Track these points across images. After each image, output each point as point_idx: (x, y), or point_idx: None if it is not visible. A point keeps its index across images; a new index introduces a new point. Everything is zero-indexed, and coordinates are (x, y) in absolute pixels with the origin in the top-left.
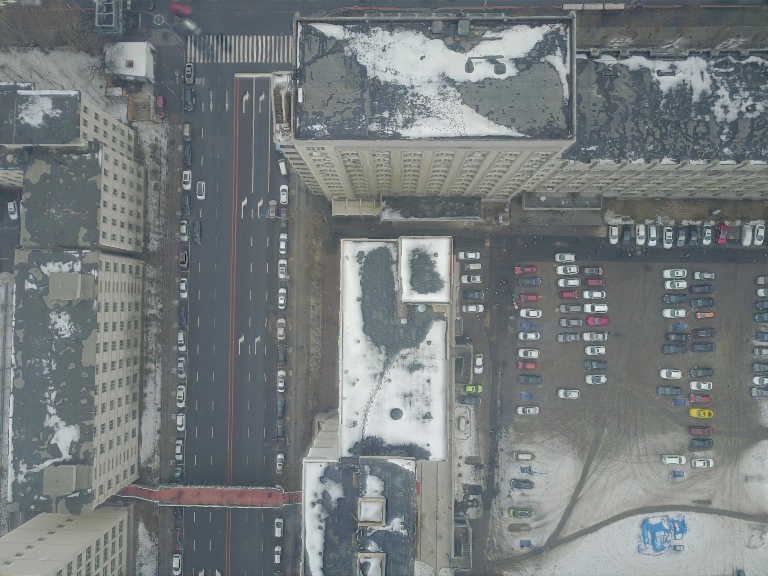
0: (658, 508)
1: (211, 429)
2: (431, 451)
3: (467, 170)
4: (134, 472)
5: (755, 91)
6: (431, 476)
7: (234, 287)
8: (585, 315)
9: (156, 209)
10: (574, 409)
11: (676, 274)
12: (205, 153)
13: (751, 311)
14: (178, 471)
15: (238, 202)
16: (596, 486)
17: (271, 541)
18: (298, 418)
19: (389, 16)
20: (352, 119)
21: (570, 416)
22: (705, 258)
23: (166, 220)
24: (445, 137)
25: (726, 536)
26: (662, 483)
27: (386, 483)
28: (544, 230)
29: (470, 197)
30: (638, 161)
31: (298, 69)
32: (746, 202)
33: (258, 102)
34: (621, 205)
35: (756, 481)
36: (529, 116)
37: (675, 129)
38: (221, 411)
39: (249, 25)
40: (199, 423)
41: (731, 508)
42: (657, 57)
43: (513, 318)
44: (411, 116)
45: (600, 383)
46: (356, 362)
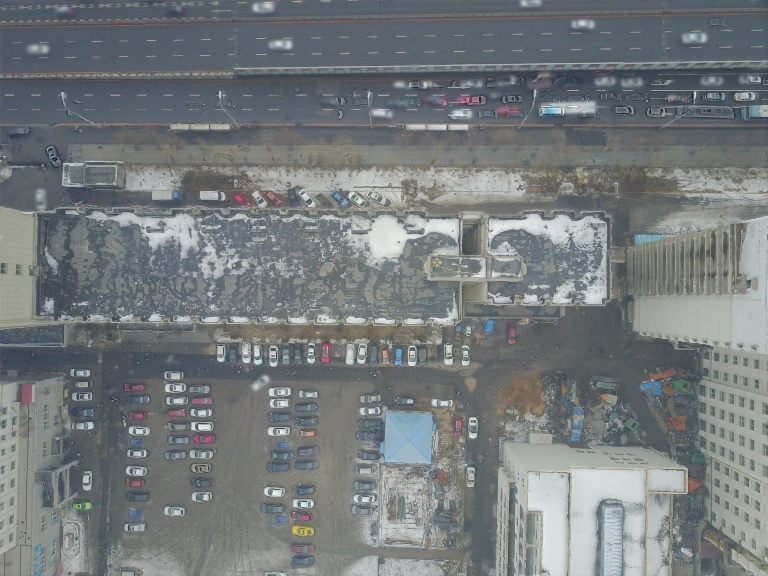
0: None
1: None
2: None
3: None
4: None
5: (241, 248)
6: None
7: None
8: (193, 432)
9: None
10: (181, 526)
11: (279, 393)
12: None
13: (355, 429)
14: None
15: None
16: None
17: None
18: None
19: None
20: None
21: (177, 532)
22: (311, 376)
23: None
24: None
25: None
26: None
27: None
28: (155, 347)
29: None
30: (127, 317)
31: None
32: None
33: None
34: None
35: None
36: None
37: (164, 285)
38: None
39: None
40: None
41: None
42: (142, 215)
43: (120, 436)
44: None
45: (205, 501)
46: None
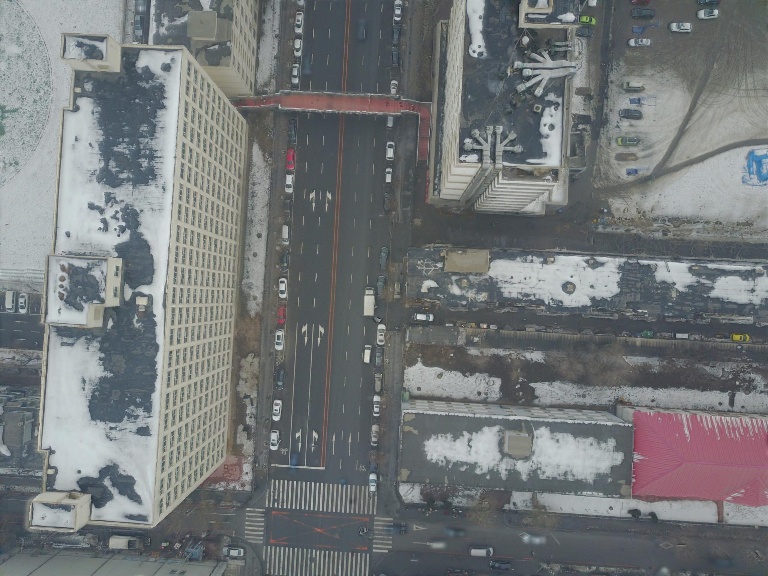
0: (764, 141)
1: (327, 56)
2: None
3: None
4: (251, 91)
5: None
6: None
7: None
8: None
9: None
10: (685, 44)
11: None
12: None
13: None
14: None
15: None
16: (703, 118)
17: (381, 165)
18: (412, 48)
19: None
20: None
21: (680, 51)
22: None
23: None
24: None
25: None
26: None
27: None
28: None
29: None
30: None
31: None
32: None
33: None
34: None
35: None
36: None
37: None
38: (337, 40)
39: None
40: (315, 50)
41: None
42: None
43: None
44: None
45: (712, 17)
46: None
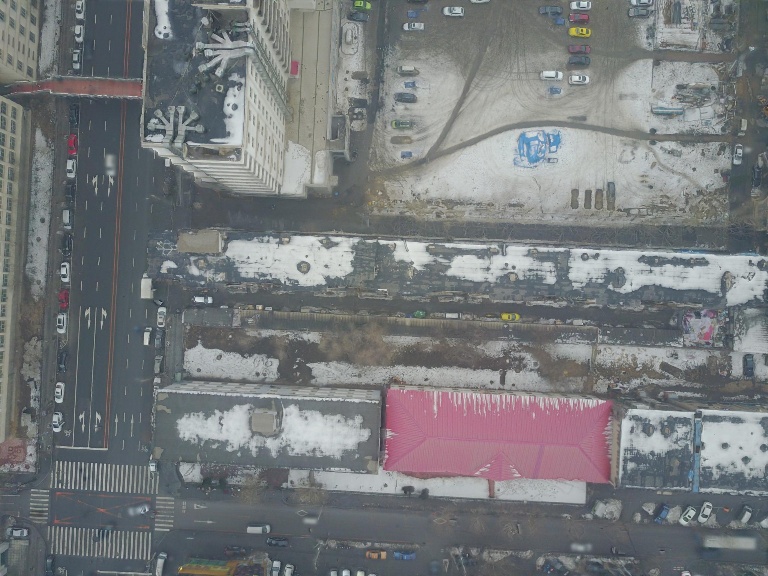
0: (535, 123)
1: (108, 42)
2: None
3: None
4: (32, 76)
5: None
6: (311, 64)
7: None
8: None
9: None
10: (458, 28)
11: None
12: None
13: None
14: None
15: None
16: (476, 101)
17: None
18: None
19: None
20: None
21: (454, 35)
22: None
23: None
24: None
25: (599, 151)
26: (540, 99)
27: None
28: None
29: None
30: None
31: None
32: None
33: None
34: None
35: (630, 99)
36: None
37: None
38: (119, 26)
39: None
40: (97, 36)
41: (605, 124)
42: None
43: None
44: None
45: (484, 1)
46: None
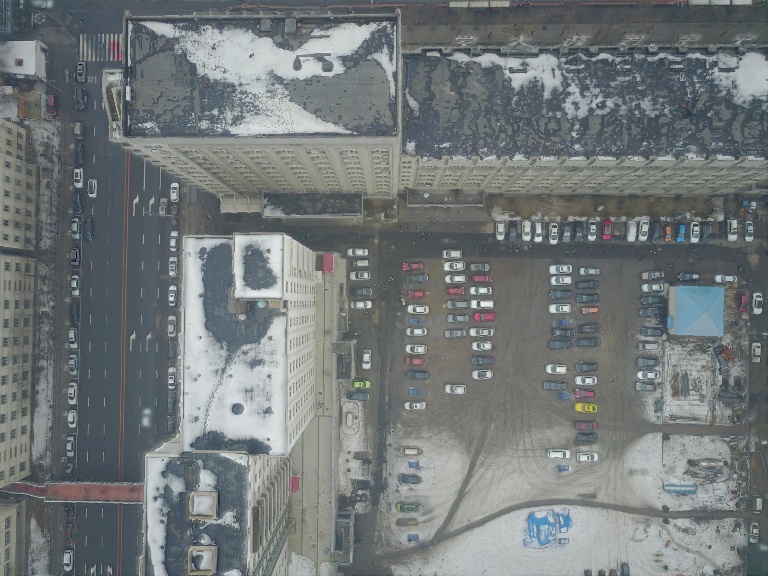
0: (544, 502)
1: (103, 426)
2: (271, 445)
3: (325, 167)
4: (25, 469)
5: (605, 88)
6: (312, 471)
7: (126, 284)
8: (472, 311)
9: (48, 207)
10: (461, 404)
11: (561, 270)
12: (97, 151)
13: (636, 306)
14: (69, 467)
15: (130, 200)
16: (483, 480)
17: None
18: None
19: (217, 14)
20: (182, 117)
21: (457, 411)
22: (591, 254)
23: (58, 218)
24: (273, 134)
25: (611, 529)
26: (548, 477)
27: (219, 477)
28: (432, 227)
29: (350, 194)
30: (490, 157)
31: (129, 67)
32: (631, 198)
33: None
34: (508, 201)
35: (640, 475)
36: (356, 113)
37: (527, 126)
38: (113, 408)
39: None
40: (91, 420)
41: (616, 501)
42: (508, 54)
43: (400, 314)
44: (240, 113)
45: (486, 378)
46: (198, 358)
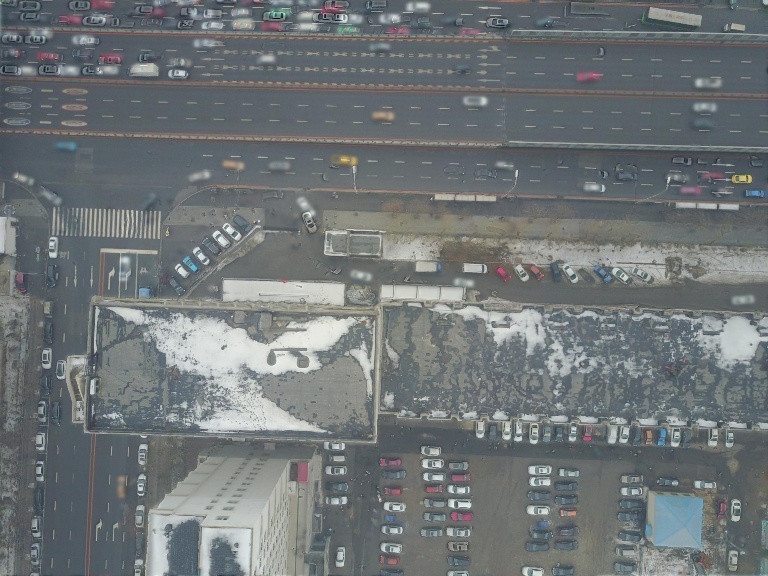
0: None
1: None
2: None
3: None
4: None
5: (589, 346)
6: None
7: (93, 471)
8: (449, 509)
9: (14, 387)
10: None
11: (540, 471)
12: (67, 330)
13: (615, 509)
14: None
15: None
16: None
17: None
18: None
19: (189, 305)
20: (149, 409)
21: None
22: (571, 454)
23: (24, 400)
24: (245, 431)
25: None
26: None
27: None
28: (411, 421)
29: None
30: (470, 414)
31: (95, 354)
32: None
33: (124, 279)
34: None
35: None
36: (331, 412)
37: (508, 382)
38: None
39: (117, 198)
40: None
41: None
42: (491, 310)
43: (376, 512)
44: (210, 408)
45: None
46: None
